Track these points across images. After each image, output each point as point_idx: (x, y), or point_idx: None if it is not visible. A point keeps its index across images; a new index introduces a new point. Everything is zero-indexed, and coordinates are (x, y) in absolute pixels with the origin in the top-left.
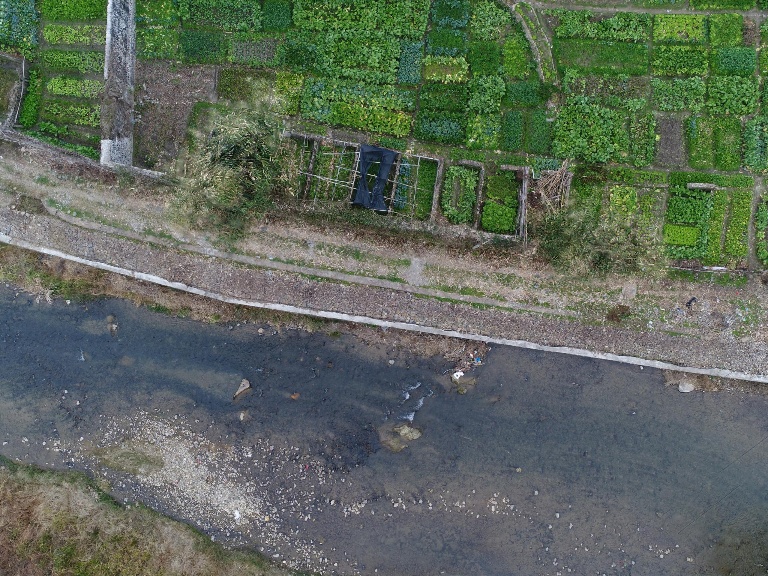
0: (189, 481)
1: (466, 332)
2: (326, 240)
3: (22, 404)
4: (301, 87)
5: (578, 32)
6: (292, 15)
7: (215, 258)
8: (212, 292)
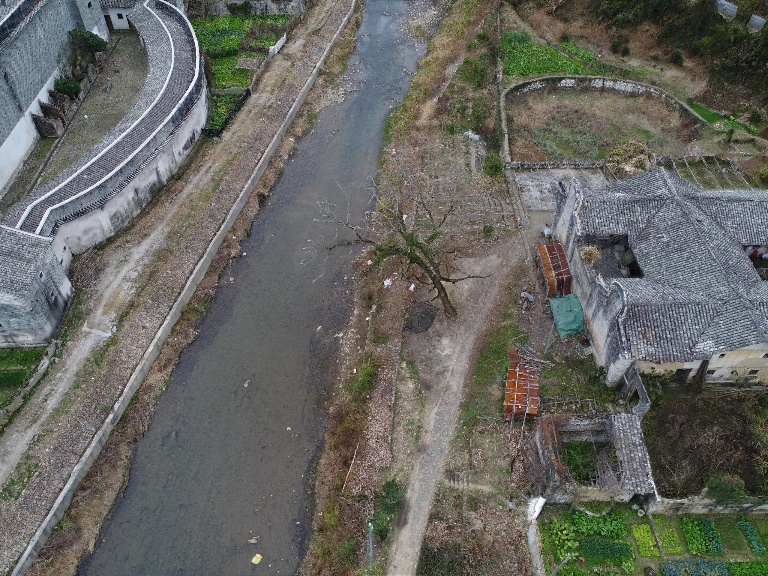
0: None
1: None
2: None
3: None
4: None
5: None
6: None
7: None
8: None
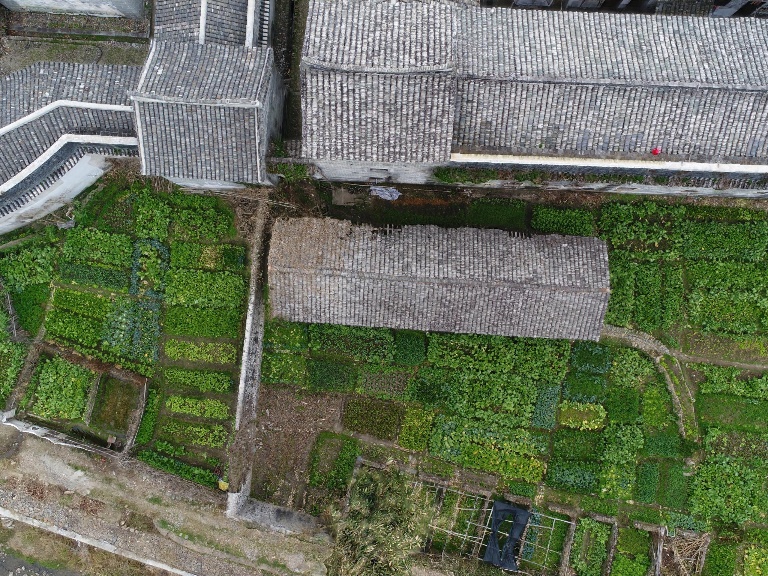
0: None
1: None
2: None
3: None
4: (431, 425)
5: (723, 389)
6: (427, 352)
7: None
8: None
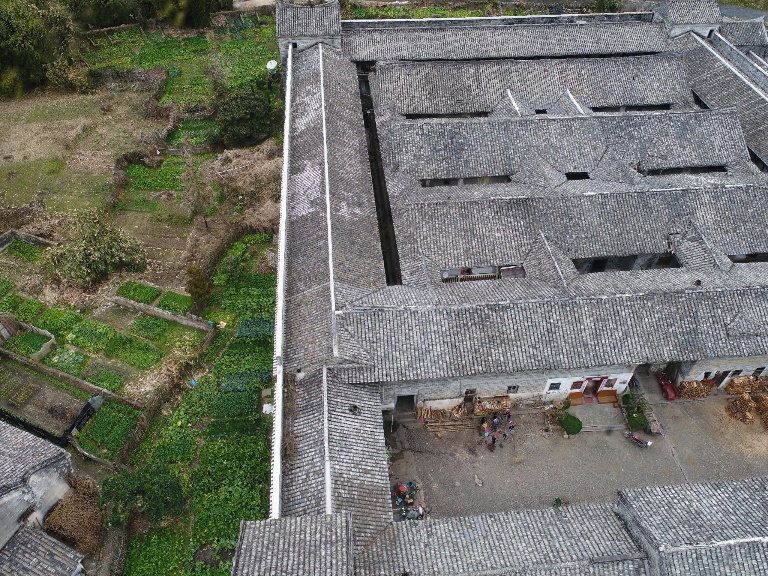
0: None
1: None
2: None
3: None
4: None
5: None
6: None
7: None
8: None
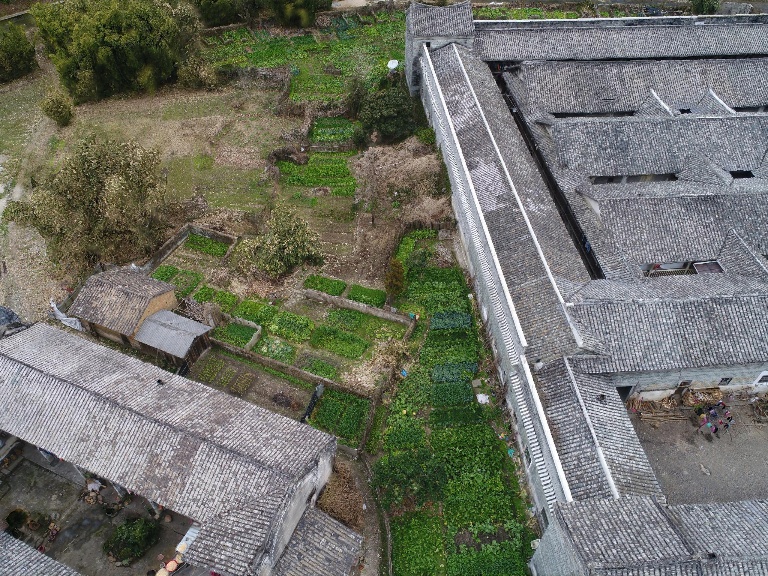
0: None
1: None
2: None
3: None
4: None
5: None
6: None
7: None
8: None
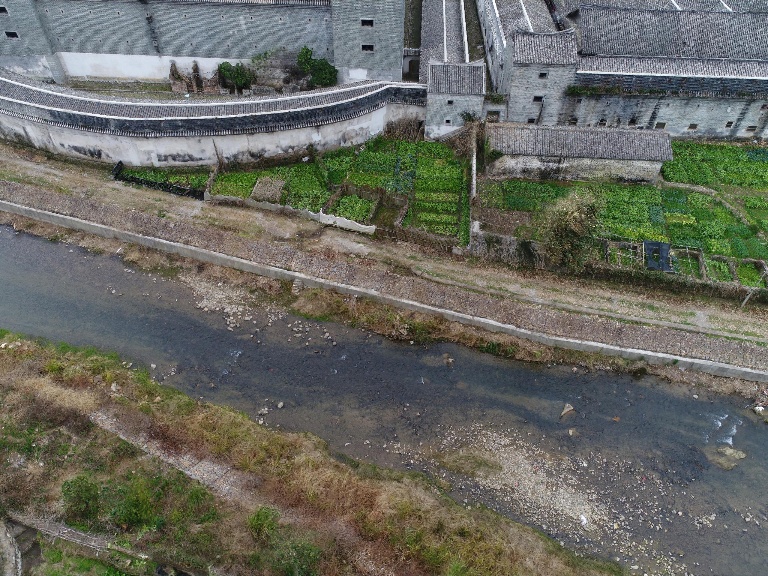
0: (529, 485)
1: (756, 369)
2: (625, 298)
3: (366, 413)
4: None
5: (760, 206)
6: (575, 192)
7: (541, 306)
8: (537, 332)
